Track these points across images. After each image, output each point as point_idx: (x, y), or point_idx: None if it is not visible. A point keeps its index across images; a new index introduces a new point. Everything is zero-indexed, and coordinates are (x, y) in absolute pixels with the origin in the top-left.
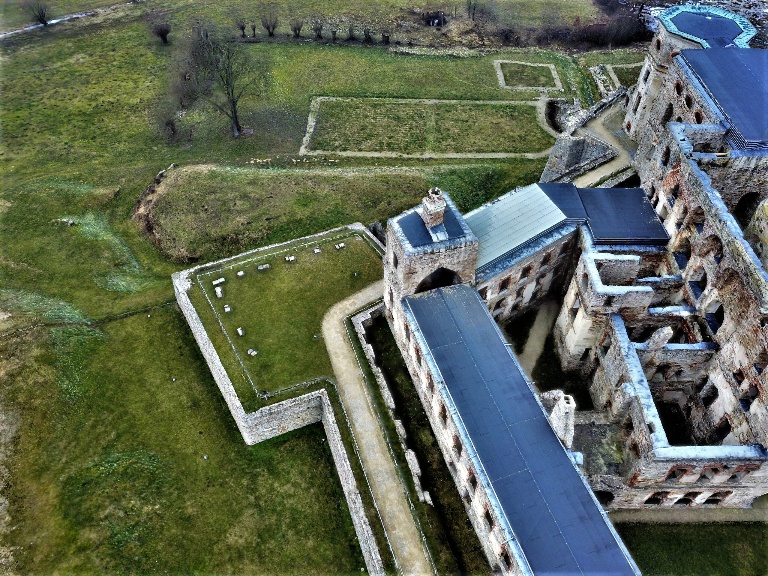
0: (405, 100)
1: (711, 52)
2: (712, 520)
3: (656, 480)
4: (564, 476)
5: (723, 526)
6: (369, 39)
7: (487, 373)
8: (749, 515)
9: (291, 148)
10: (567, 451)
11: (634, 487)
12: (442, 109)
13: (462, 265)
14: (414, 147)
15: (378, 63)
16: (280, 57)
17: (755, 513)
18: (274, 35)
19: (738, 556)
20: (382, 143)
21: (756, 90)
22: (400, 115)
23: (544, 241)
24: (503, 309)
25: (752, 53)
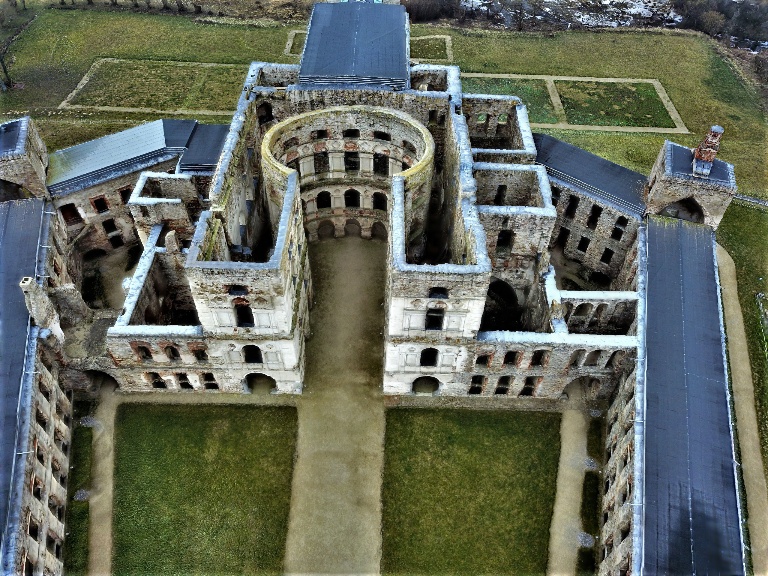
0: (185, 63)
1: (339, 5)
2: (210, 402)
3: (132, 359)
4: (11, 344)
5: (216, 407)
6: (181, 9)
7: (4, 267)
8: (245, 399)
9: (53, 102)
10: (35, 327)
11: (120, 367)
12: (215, 72)
13: (23, 178)
14: (171, 104)
15: (177, 30)
16: (85, 22)
17: (252, 397)
18: (93, 3)
19: (212, 429)
20: (142, 100)
21: (347, 36)
22: (172, 76)
23: (137, 166)
24: (120, 231)
25: (376, 7)
